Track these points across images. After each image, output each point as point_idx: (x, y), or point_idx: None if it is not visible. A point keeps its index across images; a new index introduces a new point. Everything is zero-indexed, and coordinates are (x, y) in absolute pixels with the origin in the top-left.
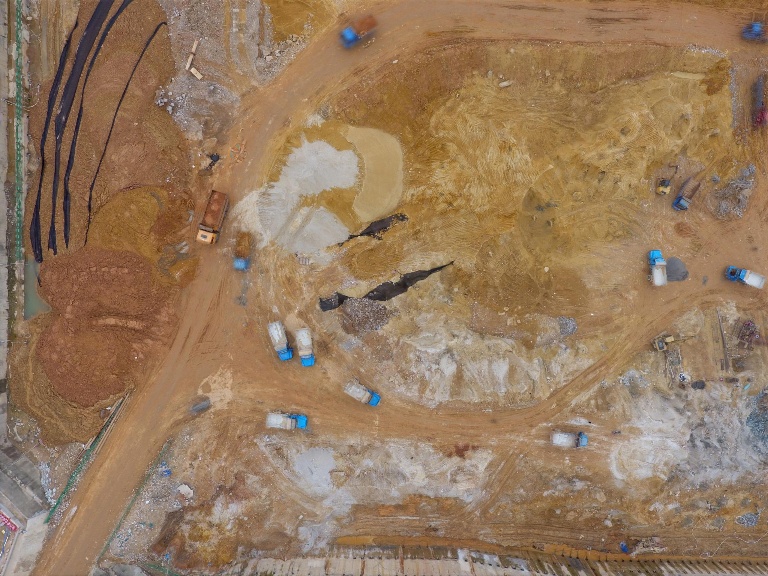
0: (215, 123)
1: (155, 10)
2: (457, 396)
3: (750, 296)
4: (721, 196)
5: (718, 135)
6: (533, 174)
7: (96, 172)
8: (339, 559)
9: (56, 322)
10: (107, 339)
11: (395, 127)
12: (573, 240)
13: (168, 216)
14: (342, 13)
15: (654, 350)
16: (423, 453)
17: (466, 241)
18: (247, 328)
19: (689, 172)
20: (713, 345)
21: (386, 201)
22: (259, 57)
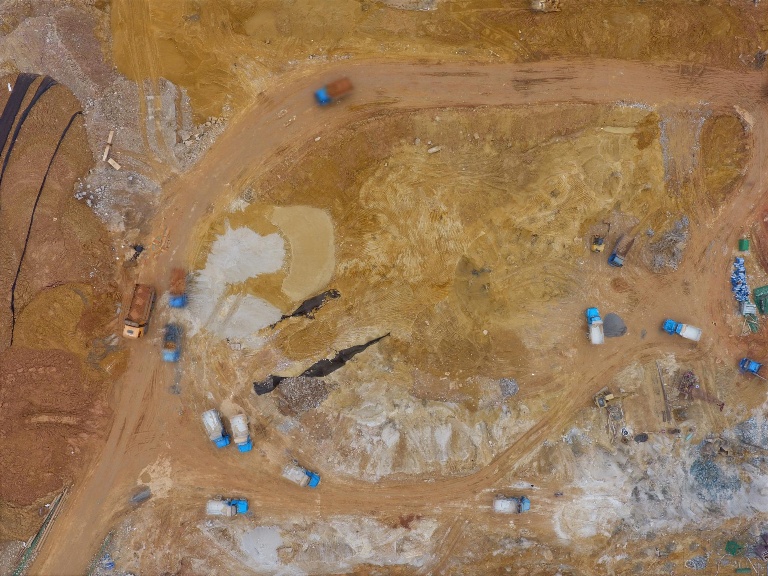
0: (136, 213)
1: (69, 100)
2: (399, 468)
3: (689, 347)
4: (656, 250)
5: (651, 189)
6: (465, 242)
7: (17, 271)
8: None
9: None
10: (41, 437)
11: (324, 201)
12: (509, 303)
13: (94, 311)
14: (261, 92)
15: (596, 406)
16: (368, 527)
17: (401, 313)
18: (183, 416)
19: (623, 227)
20: (654, 398)
21: (318, 278)
22: (178, 142)
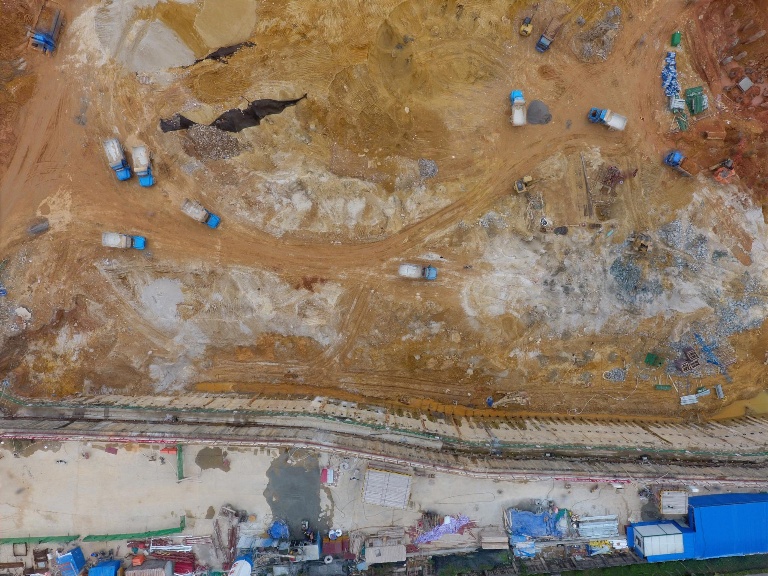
0: None
1: None
2: (306, 227)
3: (615, 141)
4: (586, 38)
5: None
6: (388, 5)
7: None
8: (190, 397)
9: None
10: None
11: None
12: (432, 77)
13: (2, 28)
14: None
15: (516, 194)
16: (269, 283)
17: (318, 72)
18: (87, 148)
19: (554, 14)
20: (577, 191)
21: (235, 28)
22: None
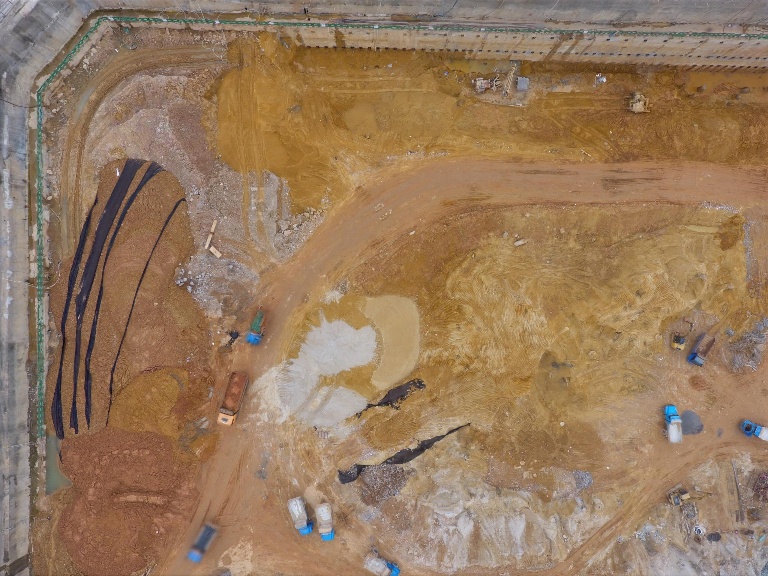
0: (234, 301)
1: (174, 186)
2: (475, 560)
3: (765, 448)
4: (735, 349)
5: None
6: (549, 337)
7: (117, 354)
8: None
9: (78, 501)
10: (128, 517)
11: (411, 290)
12: (589, 398)
13: (188, 396)
14: (359, 186)
15: (669, 503)
16: None
17: (483, 404)
18: (267, 501)
19: (703, 325)
20: (728, 497)
21: (403, 367)
22: (277, 232)
